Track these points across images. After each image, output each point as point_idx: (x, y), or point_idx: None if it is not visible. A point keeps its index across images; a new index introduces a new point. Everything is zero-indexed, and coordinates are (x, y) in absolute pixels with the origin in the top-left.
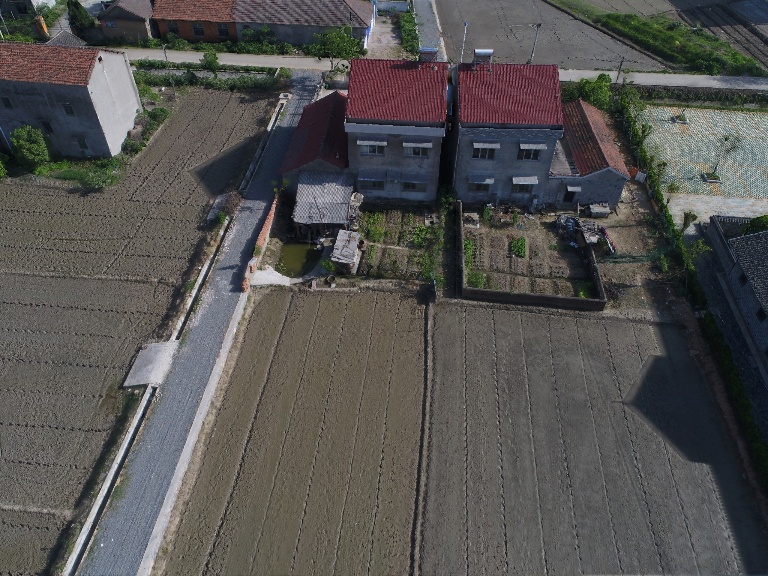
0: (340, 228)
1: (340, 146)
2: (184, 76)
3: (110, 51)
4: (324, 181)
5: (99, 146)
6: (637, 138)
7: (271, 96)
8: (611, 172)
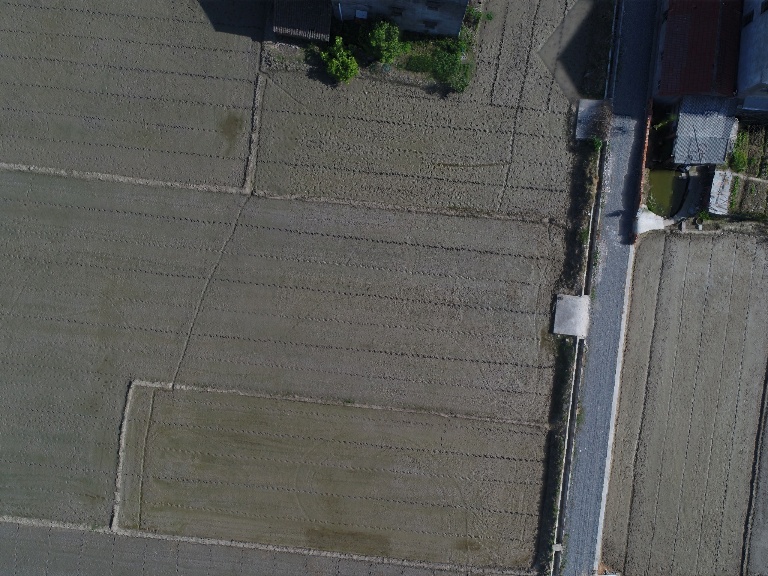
0: None
1: (730, 59)
2: None
3: None
4: (707, 109)
5: (448, 29)
6: None
7: None
8: None
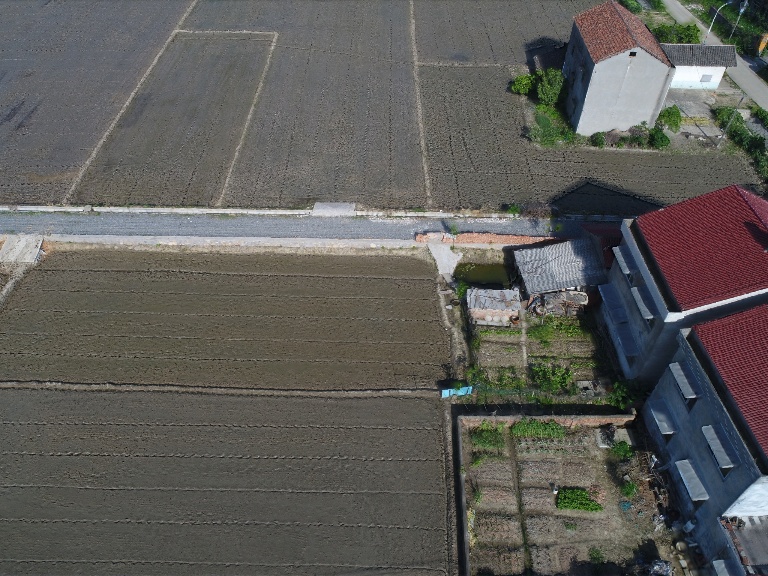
0: None
1: None
2: (751, 140)
3: (653, 55)
4: (583, 259)
5: (577, 119)
6: None
7: None
8: None
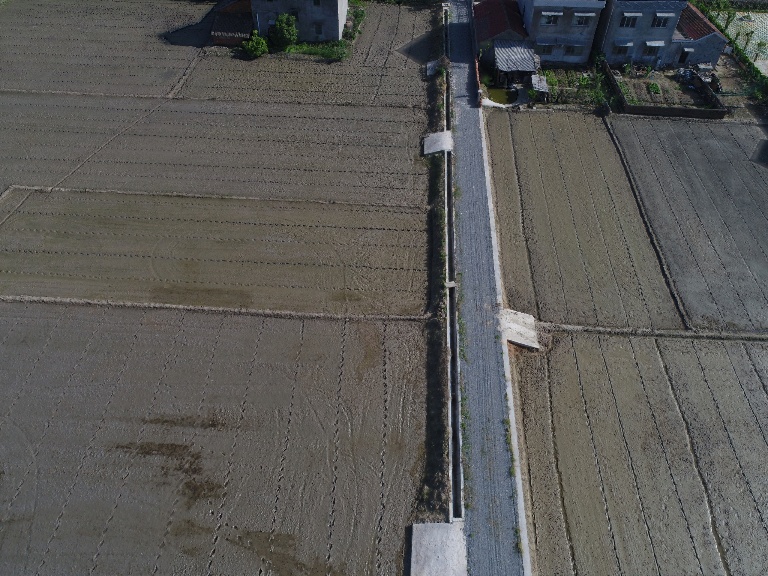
0: (528, 76)
1: (518, 24)
2: None
3: None
4: (512, 46)
5: (331, 31)
6: (720, 27)
7: (432, 7)
8: (716, 36)
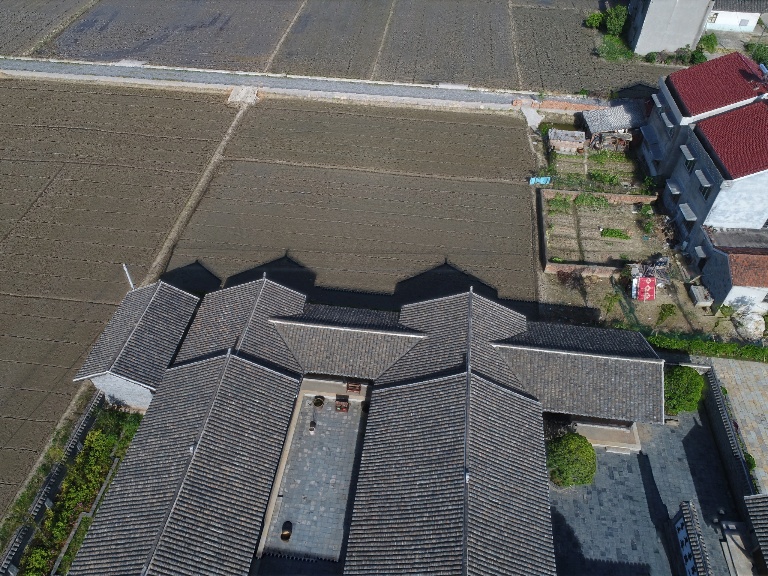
0: None
1: None
2: None
3: None
4: (631, 114)
5: None
6: None
7: None
8: None
